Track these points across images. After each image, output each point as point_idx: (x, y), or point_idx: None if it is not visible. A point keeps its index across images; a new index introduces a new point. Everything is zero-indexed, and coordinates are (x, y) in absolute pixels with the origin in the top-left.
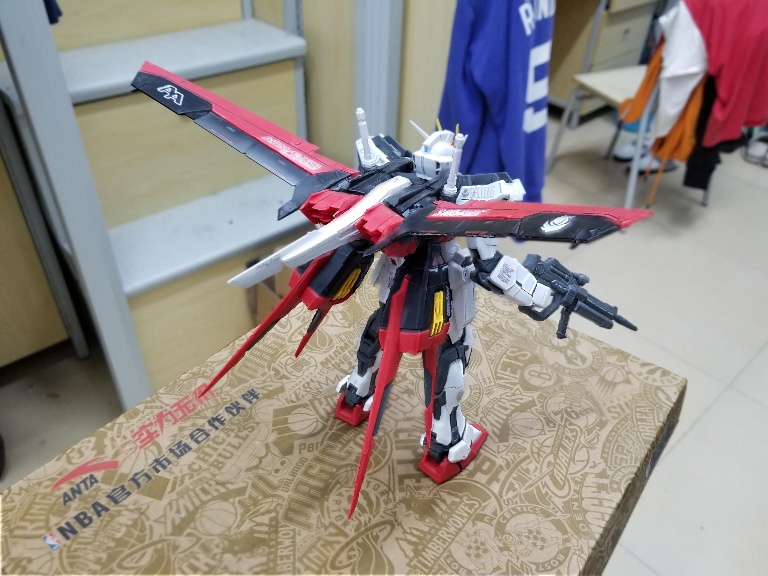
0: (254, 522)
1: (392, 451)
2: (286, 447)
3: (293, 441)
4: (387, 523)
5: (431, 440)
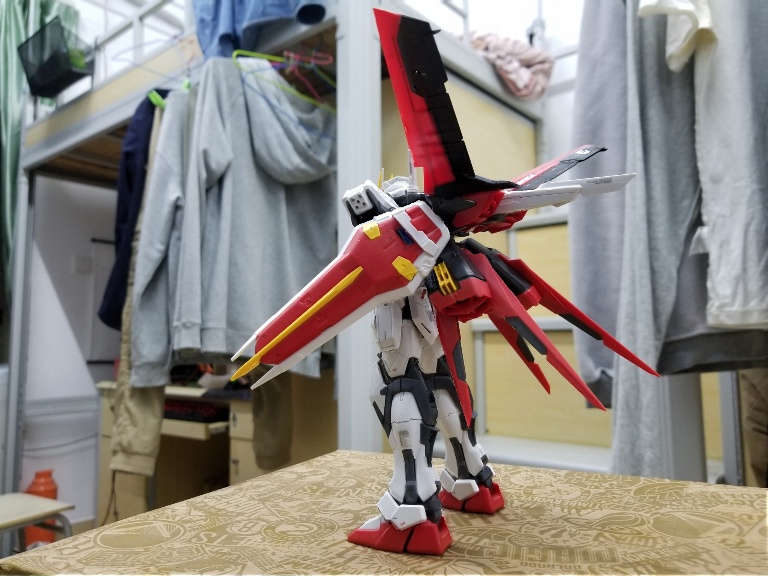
0: (640, 575)
1: (476, 526)
2: (512, 575)
3: (499, 573)
4: (568, 520)
5: (482, 471)
